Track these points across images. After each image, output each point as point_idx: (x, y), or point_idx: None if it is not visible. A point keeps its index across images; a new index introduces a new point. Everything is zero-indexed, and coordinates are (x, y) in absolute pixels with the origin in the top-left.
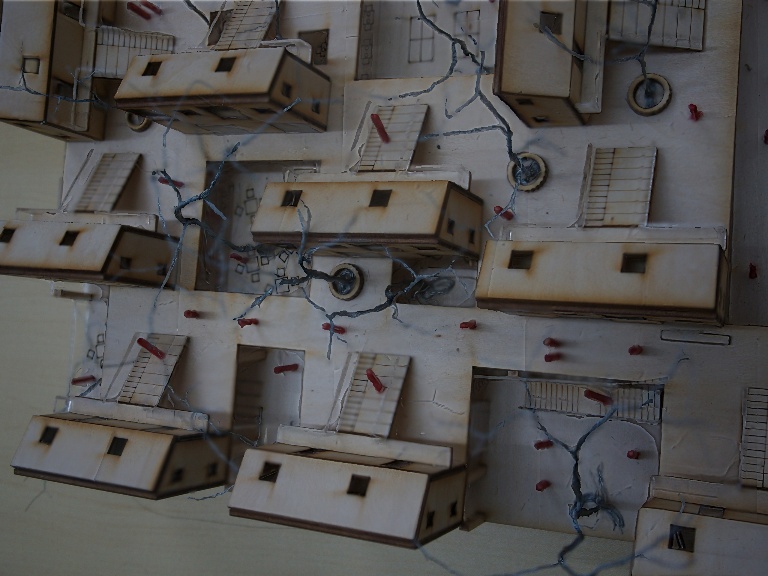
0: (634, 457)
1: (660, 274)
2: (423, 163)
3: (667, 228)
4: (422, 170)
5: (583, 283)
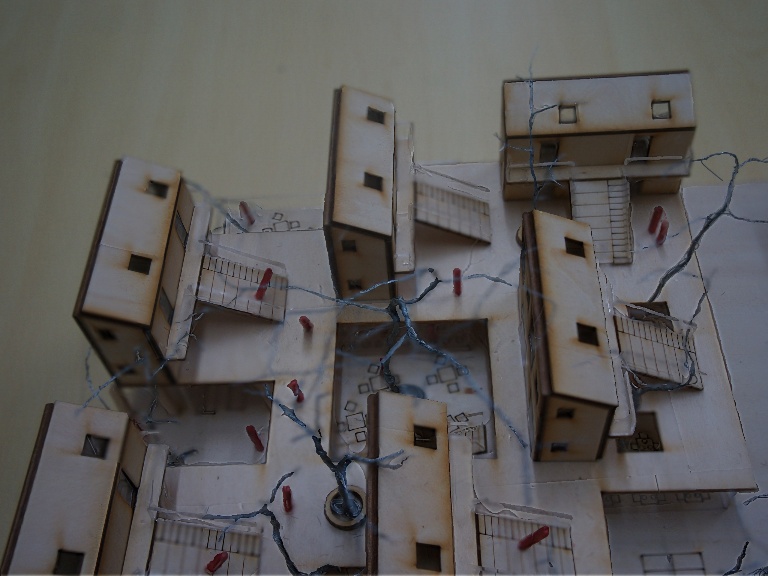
0: None
1: None
2: None
3: None
4: None
5: None
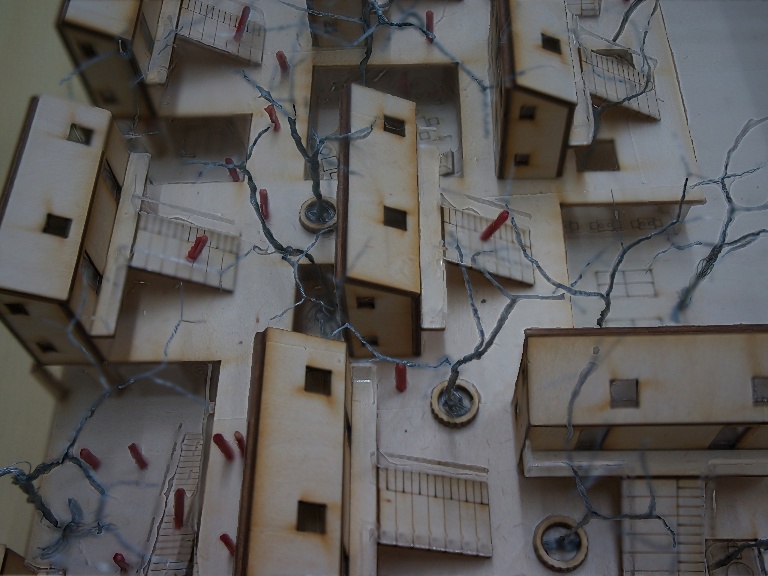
0: (116, 562)
1: (295, 550)
2: (463, 285)
3: (376, 569)
4: (455, 285)
5: (284, 454)
